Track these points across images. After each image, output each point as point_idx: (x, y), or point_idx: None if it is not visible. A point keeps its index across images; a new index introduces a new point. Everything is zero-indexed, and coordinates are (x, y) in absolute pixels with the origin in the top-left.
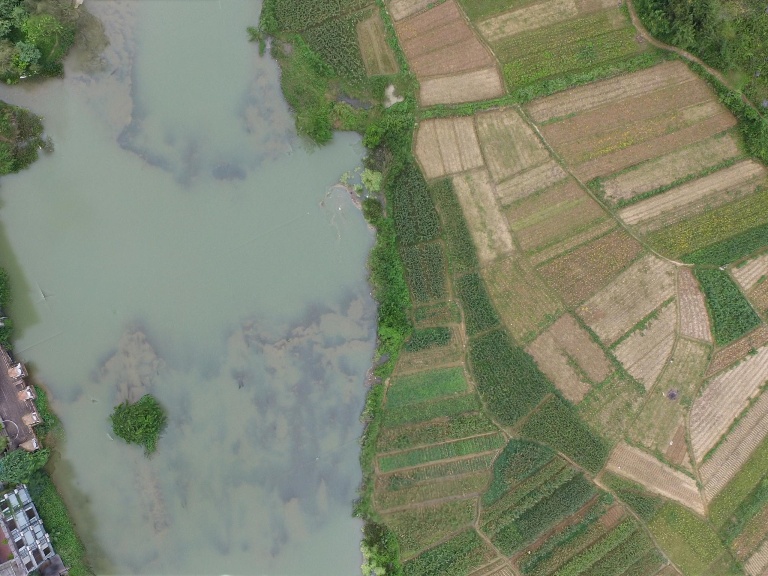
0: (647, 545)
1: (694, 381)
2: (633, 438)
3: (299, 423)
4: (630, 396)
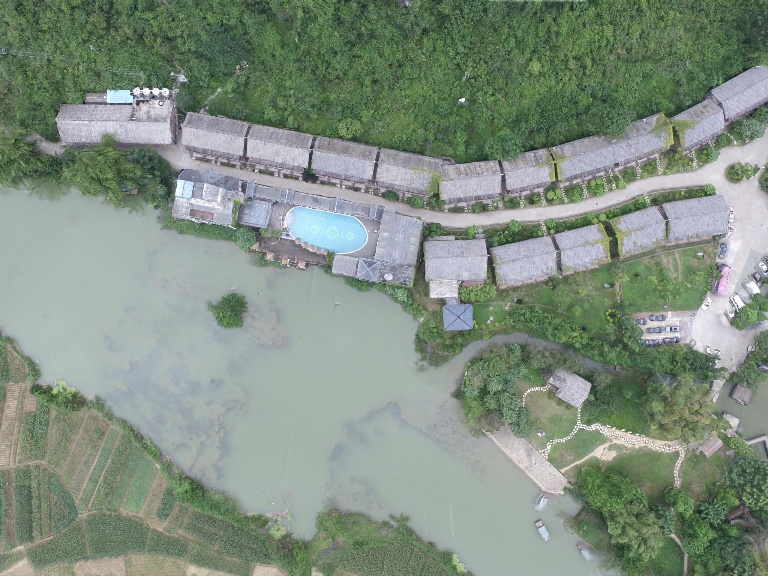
0: None
1: None
2: None
3: (170, 399)
4: None
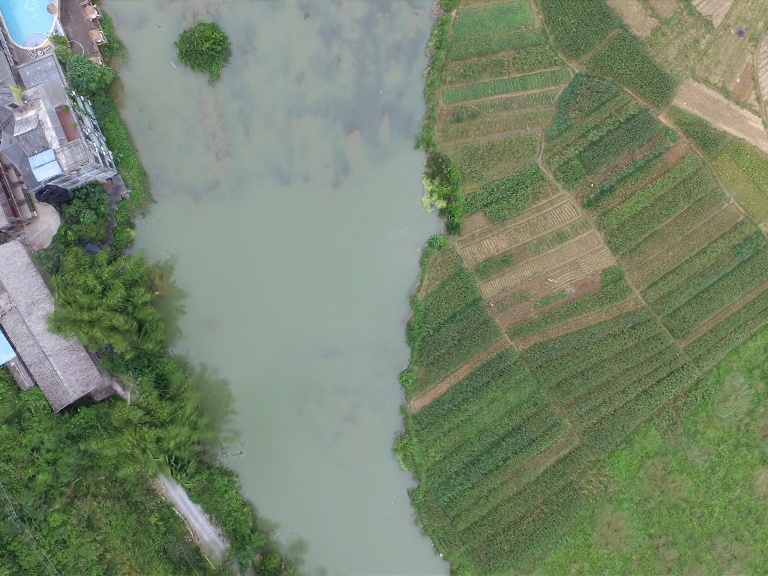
0: (711, 181)
1: (763, 19)
2: (700, 75)
3: (364, 56)
4: (698, 33)
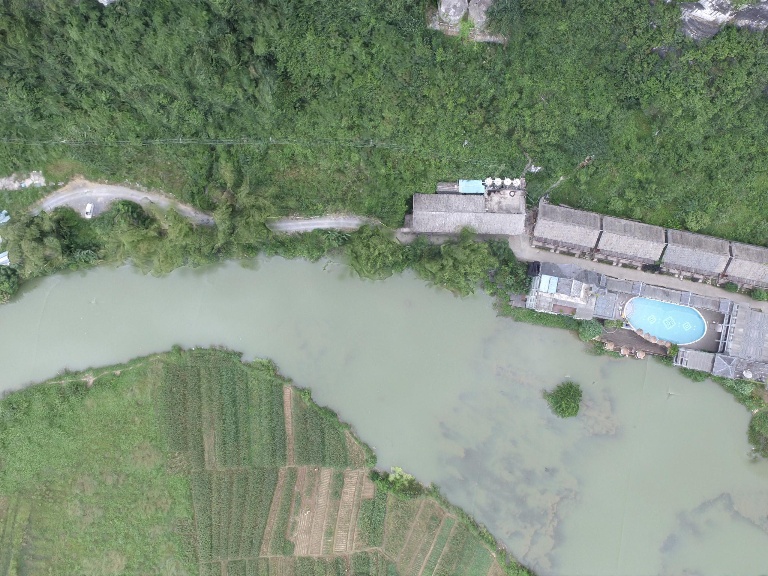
0: None
1: None
2: None
3: (504, 487)
4: None
